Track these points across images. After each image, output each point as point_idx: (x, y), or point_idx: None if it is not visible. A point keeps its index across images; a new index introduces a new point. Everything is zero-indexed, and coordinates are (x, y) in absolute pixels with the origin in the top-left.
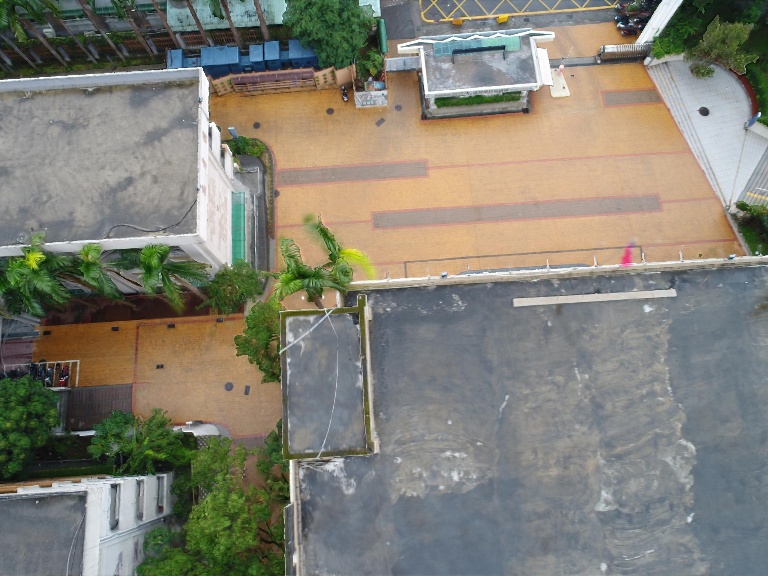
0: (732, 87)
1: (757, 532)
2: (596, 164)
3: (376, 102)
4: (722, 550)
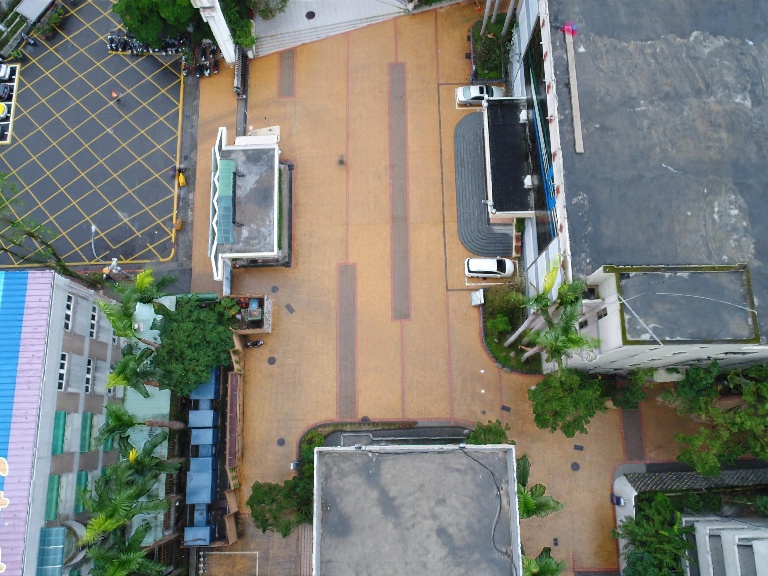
0: None
1: None
2: (355, 111)
3: (269, 311)
4: None
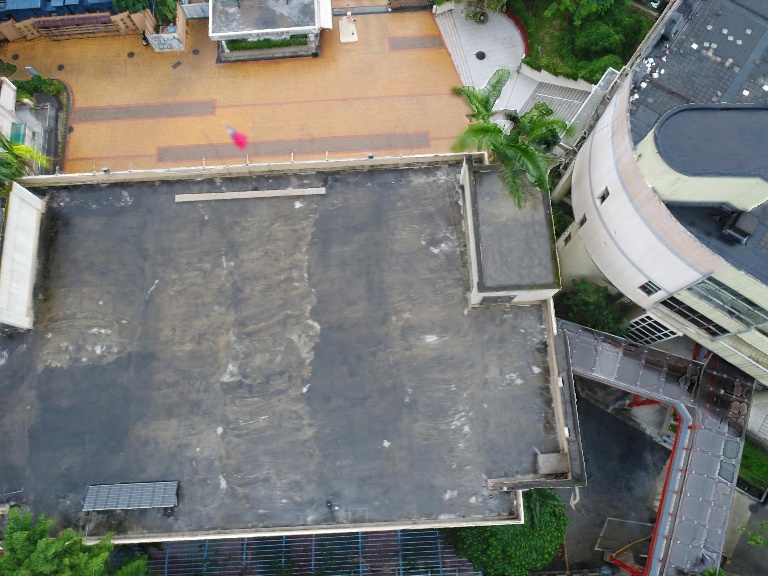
0: (510, 33)
1: (364, 401)
2: (374, 104)
3: (172, 46)
4: (330, 417)
